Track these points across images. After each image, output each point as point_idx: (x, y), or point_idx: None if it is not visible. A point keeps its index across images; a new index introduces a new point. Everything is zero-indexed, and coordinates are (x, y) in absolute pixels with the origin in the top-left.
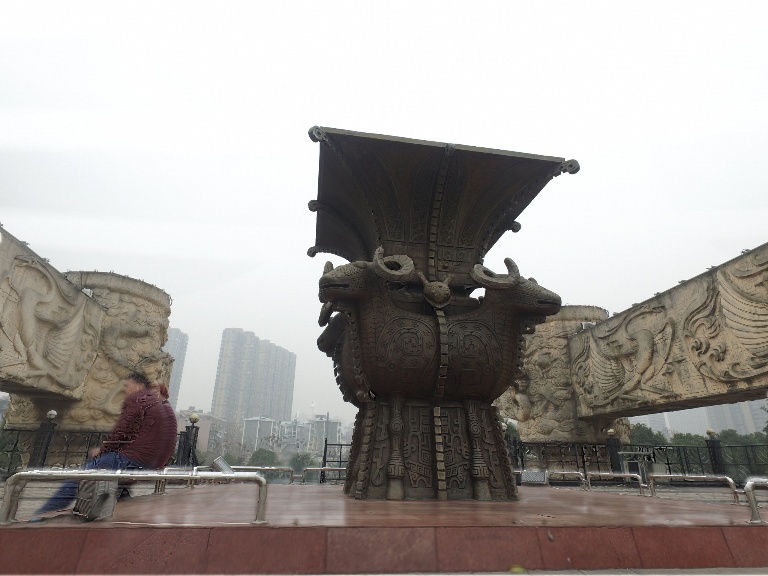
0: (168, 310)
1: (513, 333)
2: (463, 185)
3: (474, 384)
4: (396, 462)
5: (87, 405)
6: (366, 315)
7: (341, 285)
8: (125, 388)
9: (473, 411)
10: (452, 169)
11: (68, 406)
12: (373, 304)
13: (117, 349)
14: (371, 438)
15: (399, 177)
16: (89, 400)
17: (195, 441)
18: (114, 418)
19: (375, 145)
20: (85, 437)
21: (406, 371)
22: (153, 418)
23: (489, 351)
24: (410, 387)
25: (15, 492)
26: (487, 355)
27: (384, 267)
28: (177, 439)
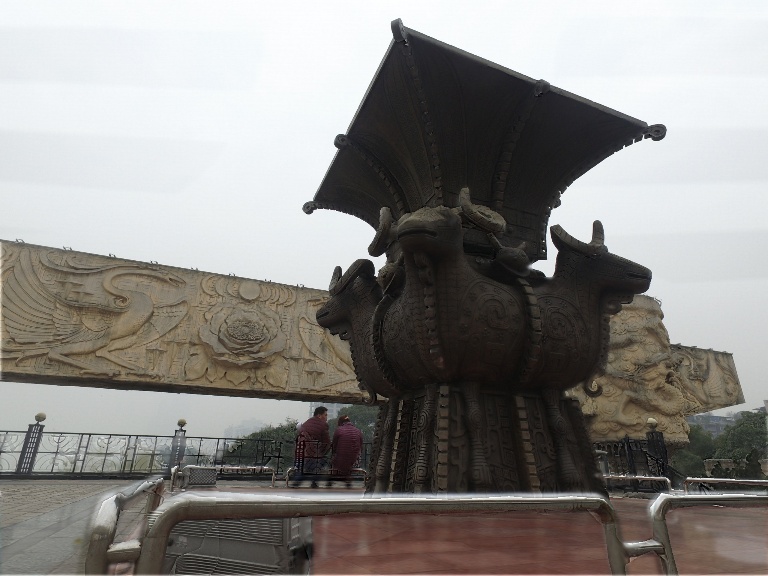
0: (651, 310)
1: (422, 288)
2: (388, 147)
3: (411, 366)
4: (378, 462)
5: (602, 419)
6: (353, 328)
7: (322, 316)
8: (630, 398)
9: (427, 398)
10: (369, 146)
11: (589, 422)
12: (353, 317)
13: (608, 363)
14: (376, 440)
15: (362, 185)
16: (603, 414)
17: (664, 448)
18: (632, 428)
19: (332, 182)
20: (616, 448)
21: (372, 370)
22: (335, 435)
23: (404, 323)
24: (386, 384)
25: (180, 474)
26: (403, 329)
27: (332, 286)
28: (643, 446)
